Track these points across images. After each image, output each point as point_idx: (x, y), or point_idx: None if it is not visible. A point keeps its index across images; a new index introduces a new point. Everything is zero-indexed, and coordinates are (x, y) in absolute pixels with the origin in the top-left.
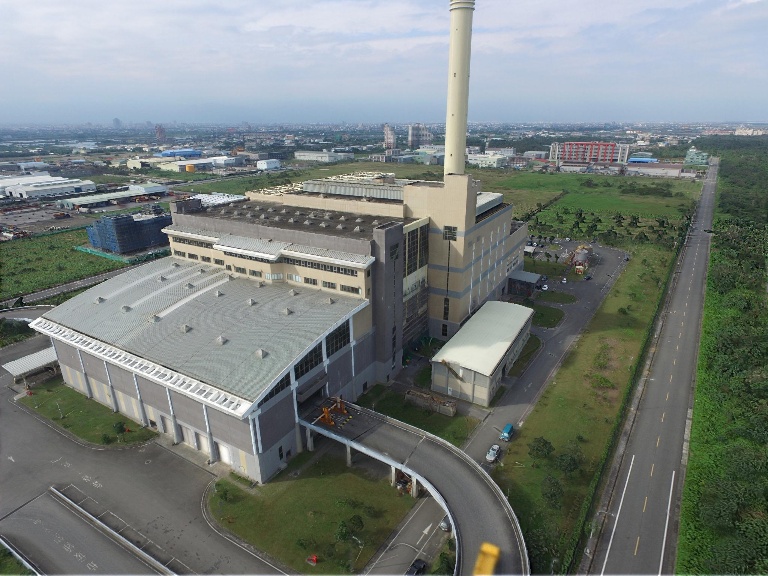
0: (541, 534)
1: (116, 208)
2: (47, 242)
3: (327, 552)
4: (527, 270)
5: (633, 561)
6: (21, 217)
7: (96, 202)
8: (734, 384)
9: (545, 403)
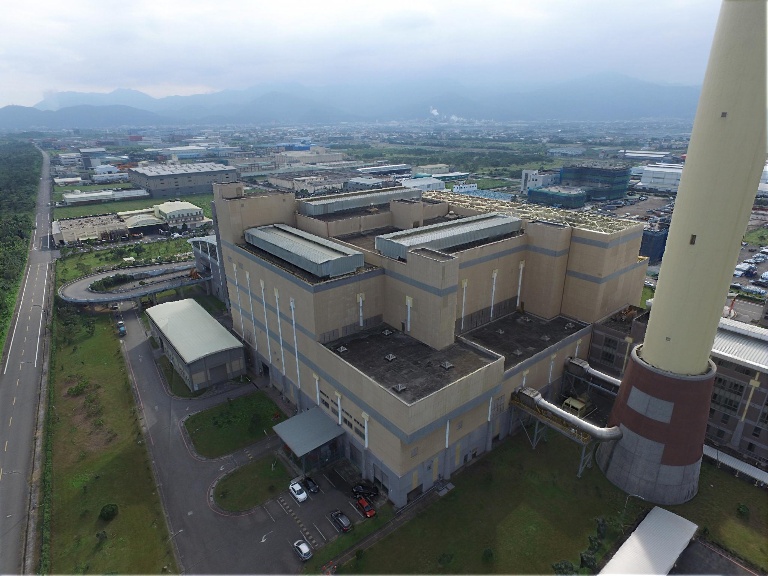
0: (67, 307)
1: None
2: None
3: None
4: (417, 528)
5: (26, 335)
6: None
7: None
8: None
9: (117, 356)
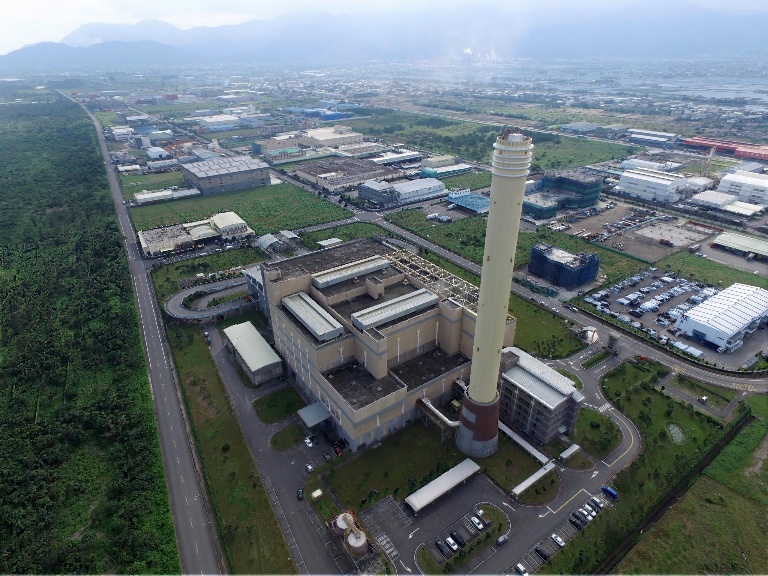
0: (173, 321)
1: (727, 260)
2: (571, 247)
3: (214, 298)
4: (360, 461)
5: None
6: (668, 231)
7: (734, 248)
8: (134, 413)
9: (209, 359)
